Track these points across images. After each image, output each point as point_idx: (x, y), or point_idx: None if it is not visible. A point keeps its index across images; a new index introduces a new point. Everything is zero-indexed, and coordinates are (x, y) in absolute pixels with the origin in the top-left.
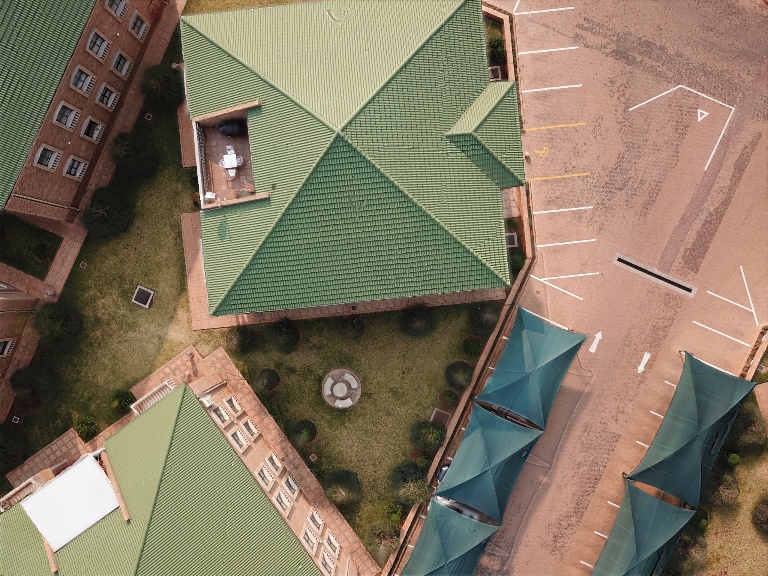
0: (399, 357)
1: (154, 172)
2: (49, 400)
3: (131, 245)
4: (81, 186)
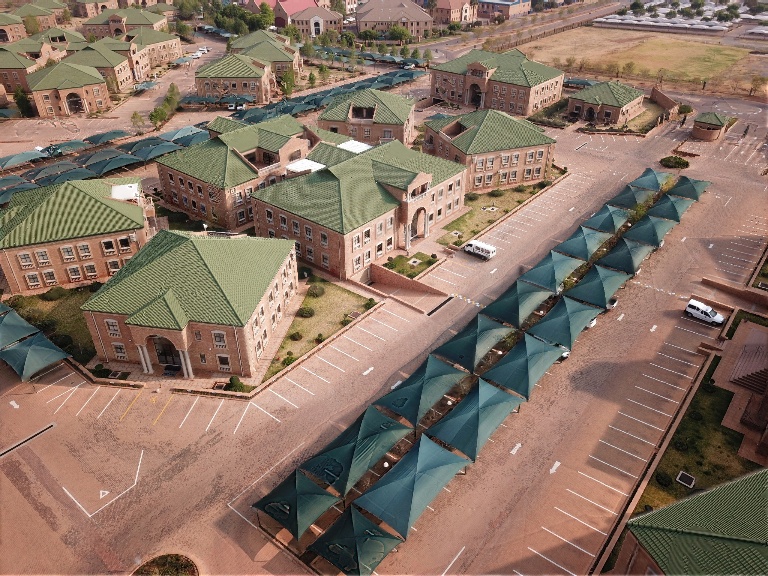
0: None
1: None
2: None
3: None
4: None
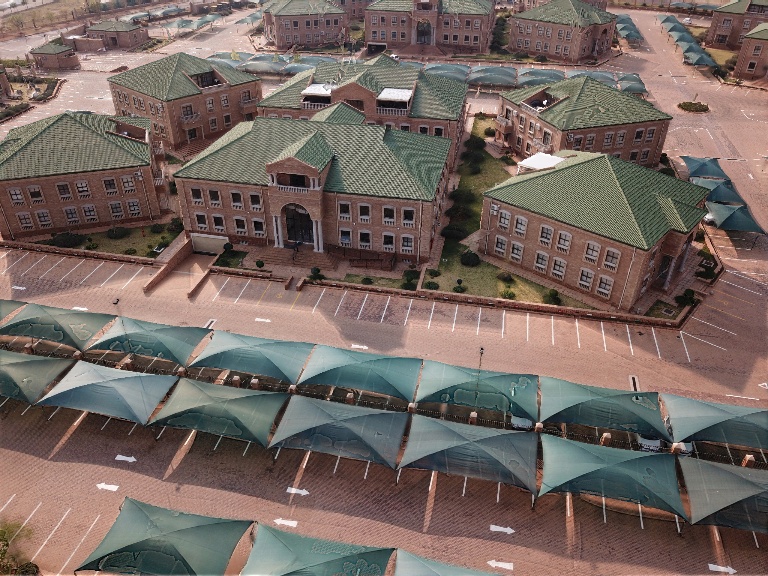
0: None
1: (483, 160)
2: (472, 213)
3: None
4: None
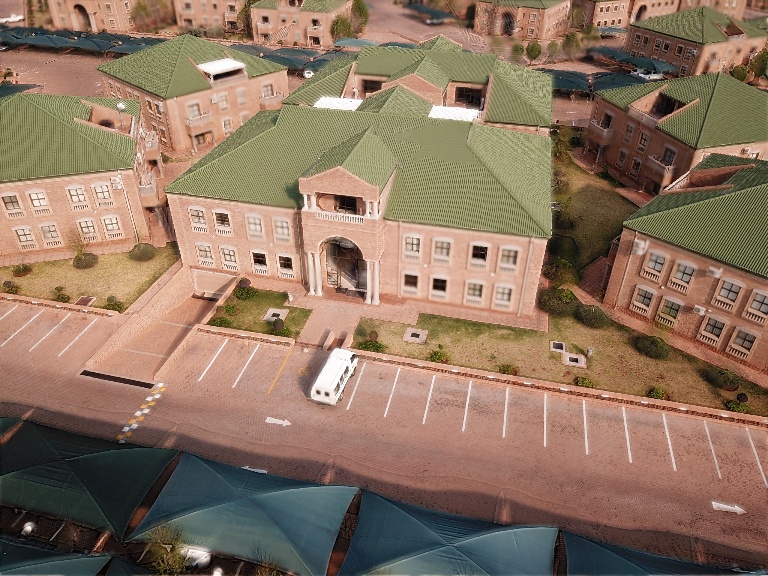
0: None
1: None
2: None
3: None
4: None
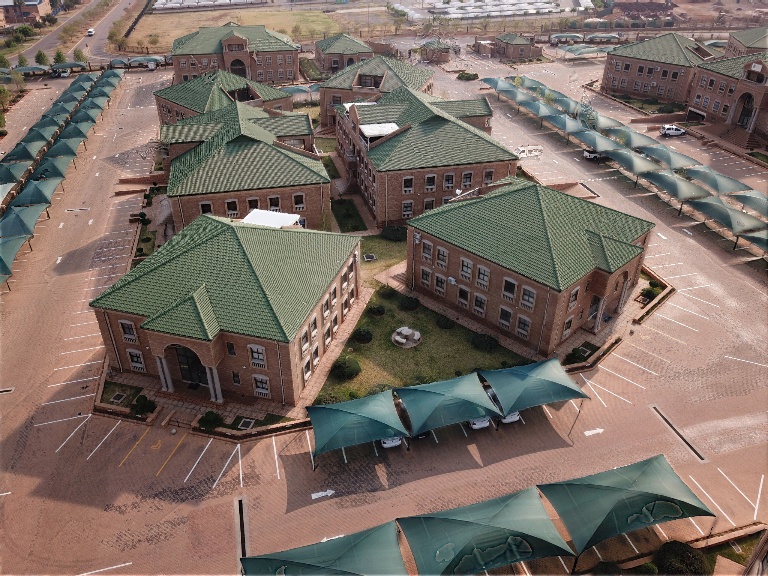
0: (455, 349)
1: None
2: None
3: (390, 245)
4: (399, 221)
